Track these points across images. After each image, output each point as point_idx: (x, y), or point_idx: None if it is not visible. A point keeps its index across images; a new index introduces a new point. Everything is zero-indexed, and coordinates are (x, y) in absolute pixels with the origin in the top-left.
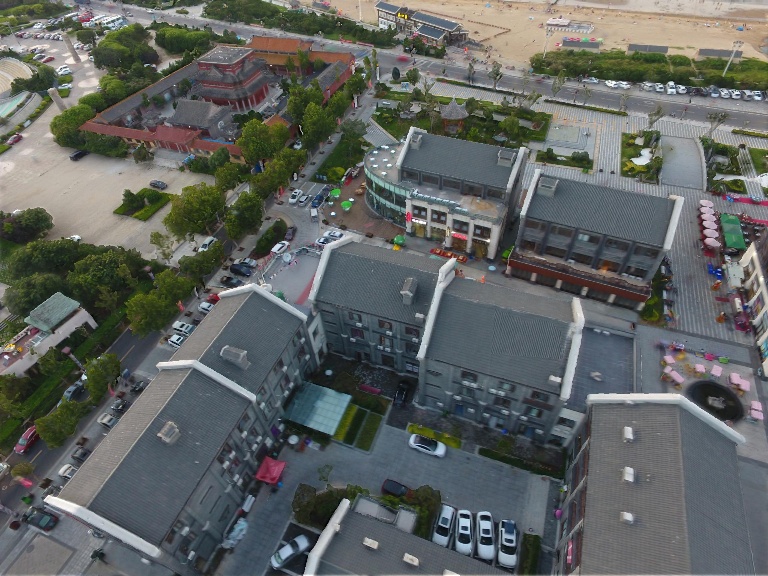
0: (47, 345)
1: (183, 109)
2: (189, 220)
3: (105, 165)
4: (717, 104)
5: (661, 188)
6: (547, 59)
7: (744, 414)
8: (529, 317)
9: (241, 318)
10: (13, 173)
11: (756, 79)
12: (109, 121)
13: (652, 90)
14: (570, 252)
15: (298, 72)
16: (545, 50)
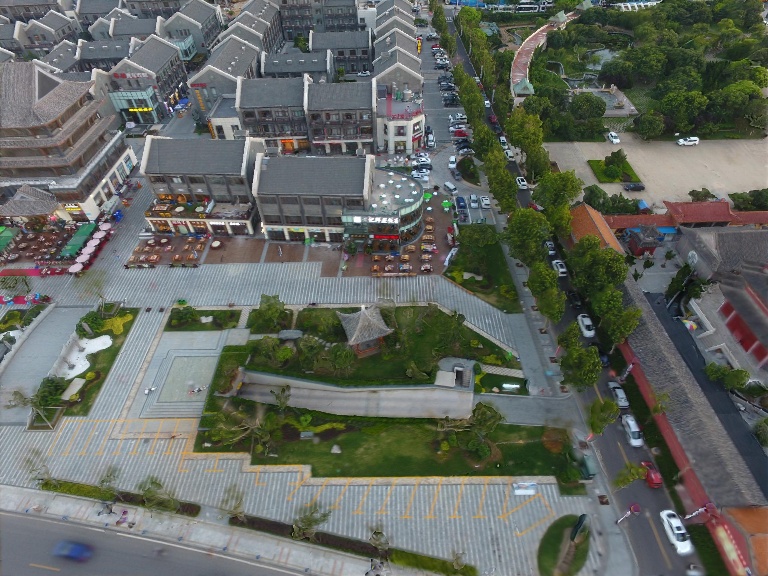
0: None
1: None
2: None
3: None
4: None
5: None
6: None
7: None
8: None
9: None
10: None
11: None
12: None
13: None
14: None
15: None
16: None
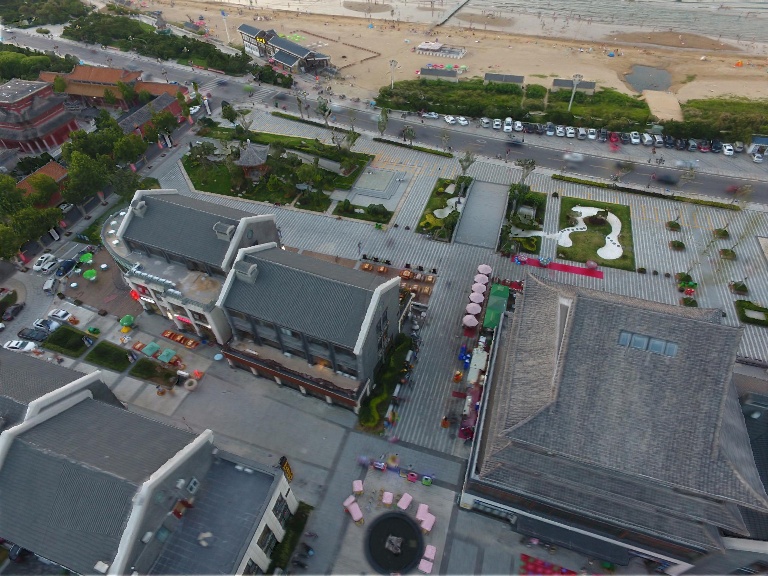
0: None
1: None
2: None
3: None
4: (550, 143)
5: (451, 247)
6: (394, 90)
7: None
8: (97, 476)
9: None
10: None
11: (600, 114)
12: None
13: (490, 127)
14: (282, 345)
15: (123, 105)
16: (392, 81)
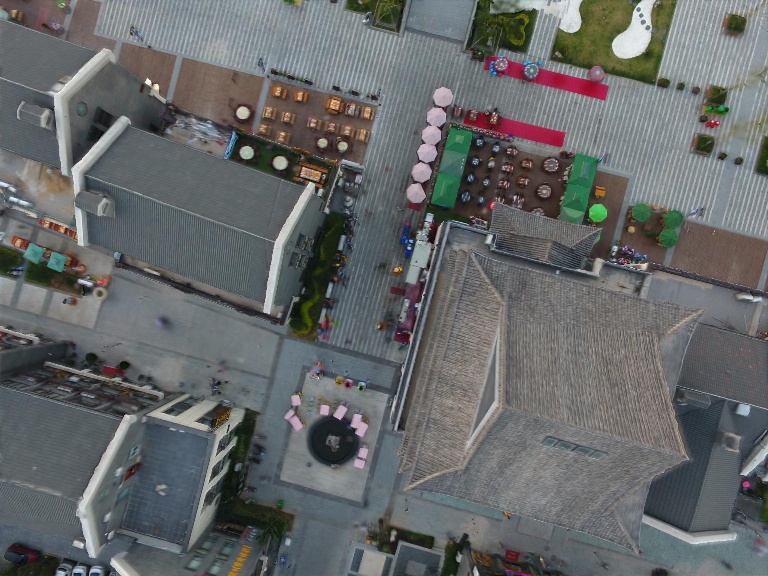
0: None
1: None
2: None
3: None
4: None
5: (400, 42)
6: None
7: (356, 453)
8: (34, 492)
9: None
10: None
11: None
12: None
13: None
14: None
15: None
16: None
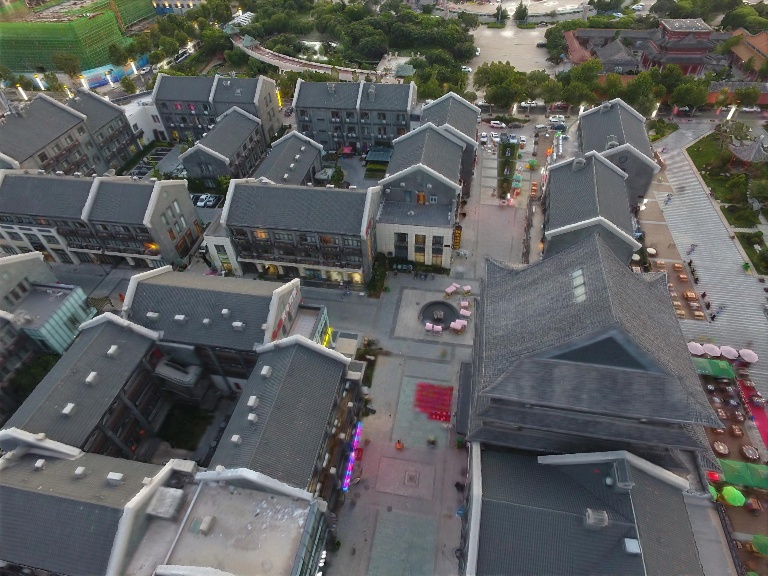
0: (390, 81)
1: (611, 46)
2: (482, 77)
3: (541, 56)
4: None
5: None
6: None
7: None
8: None
9: (393, 87)
10: (512, 38)
11: None
12: (579, 35)
13: None
14: None
15: (754, 77)
16: None
